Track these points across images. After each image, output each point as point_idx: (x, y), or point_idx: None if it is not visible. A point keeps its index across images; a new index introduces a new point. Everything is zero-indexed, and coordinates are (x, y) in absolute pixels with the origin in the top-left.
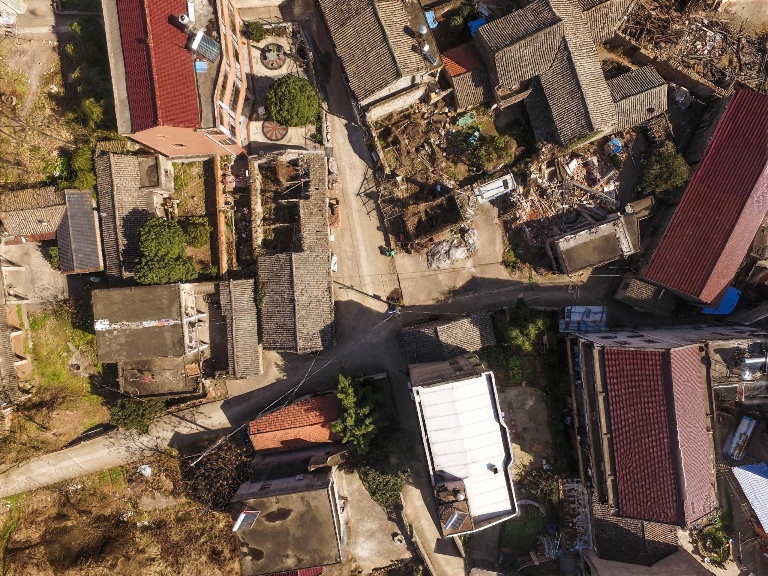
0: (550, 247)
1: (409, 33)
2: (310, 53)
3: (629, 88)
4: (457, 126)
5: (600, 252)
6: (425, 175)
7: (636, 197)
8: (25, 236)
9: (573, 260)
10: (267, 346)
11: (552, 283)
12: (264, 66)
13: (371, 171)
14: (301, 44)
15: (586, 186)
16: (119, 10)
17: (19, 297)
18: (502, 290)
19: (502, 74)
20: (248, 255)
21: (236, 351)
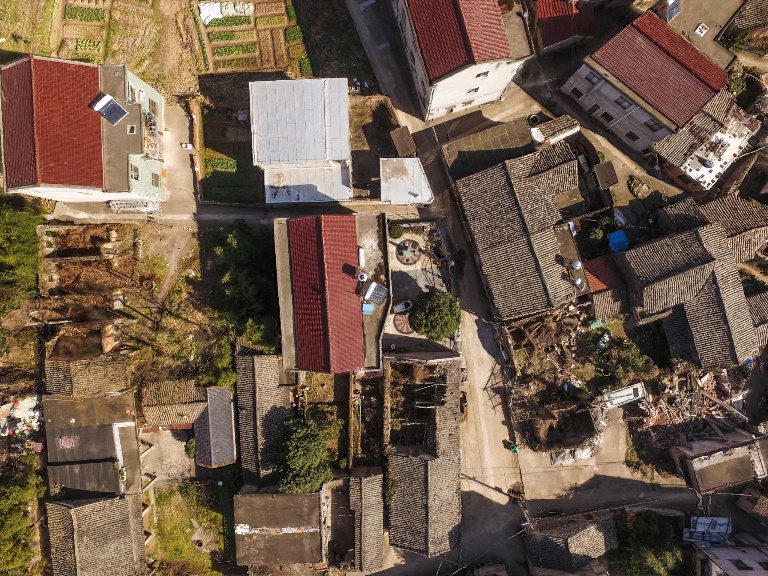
0: (680, 461)
1: (559, 261)
2: (452, 262)
3: (767, 311)
4: (587, 328)
5: (733, 474)
6: (553, 375)
7: (763, 407)
8: (162, 425)
9: (706, 480)
10: (394, 543)
11: (673, 484)
12: (399, 261)
13: (499, 367)
14: (441, 249)
15: (716, 399)
16: (292, 253)
17: (147, 475)
18: (635, 508)
19: (648, 302)
20: (377, 449)
21: (363, 546)
